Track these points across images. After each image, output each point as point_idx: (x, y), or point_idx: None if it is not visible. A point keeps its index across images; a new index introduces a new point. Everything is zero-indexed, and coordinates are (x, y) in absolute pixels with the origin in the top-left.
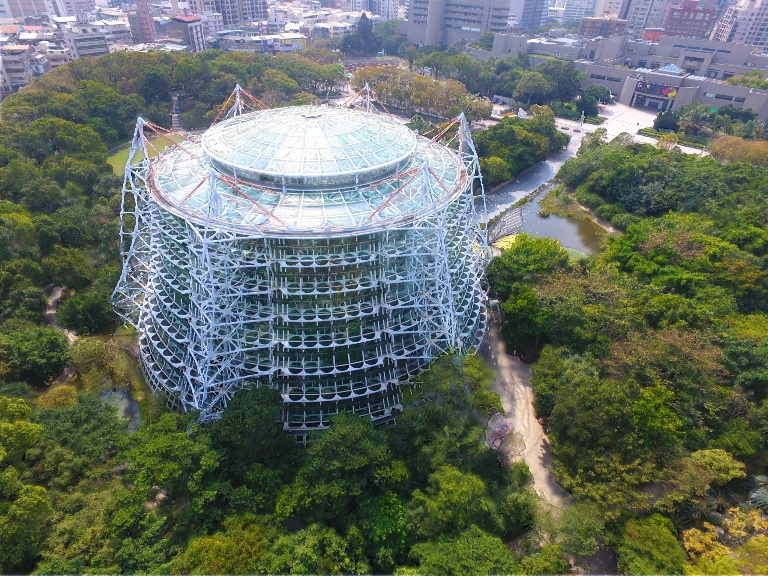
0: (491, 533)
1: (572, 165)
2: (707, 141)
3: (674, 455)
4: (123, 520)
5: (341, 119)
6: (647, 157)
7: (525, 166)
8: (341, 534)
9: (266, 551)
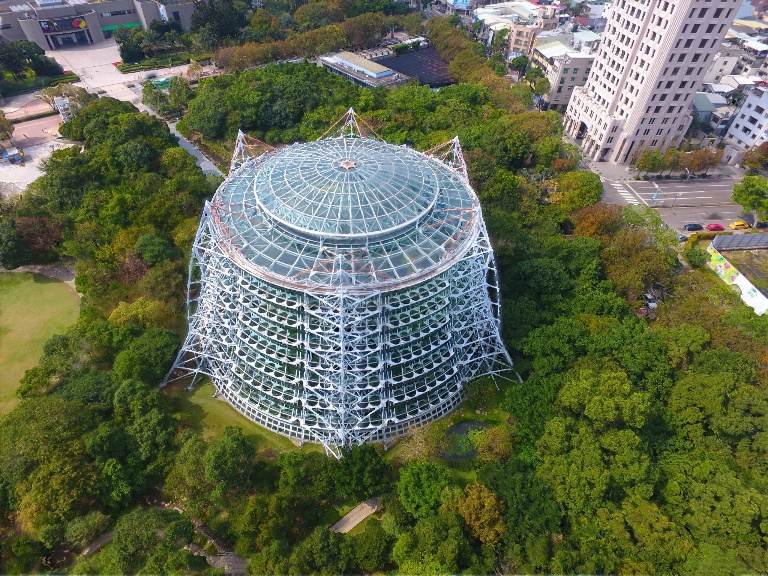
0: None
1: (201, 121)
2: (178, 56)
3: (514, 190)
4: (607, 342)
5: (358, 154)
6: (240, 87)
7: (177, 143)
8: (567, 293)
9: None
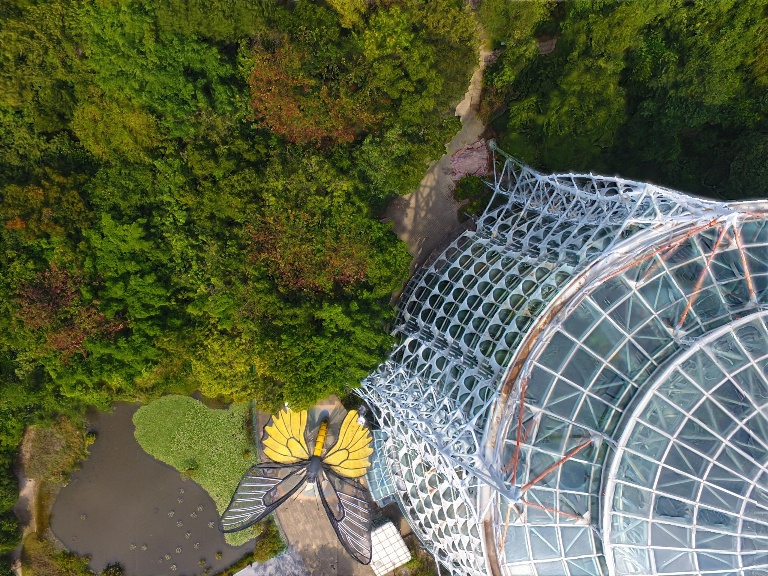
0: (574, 21)
1: None
2: None
3: None
4: None
5: None
6: None
7: None
8: None
9: (749, 55)
